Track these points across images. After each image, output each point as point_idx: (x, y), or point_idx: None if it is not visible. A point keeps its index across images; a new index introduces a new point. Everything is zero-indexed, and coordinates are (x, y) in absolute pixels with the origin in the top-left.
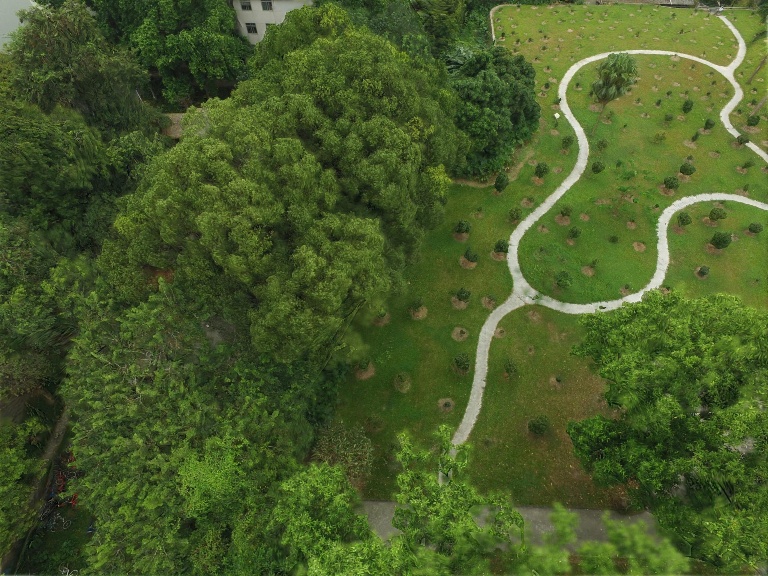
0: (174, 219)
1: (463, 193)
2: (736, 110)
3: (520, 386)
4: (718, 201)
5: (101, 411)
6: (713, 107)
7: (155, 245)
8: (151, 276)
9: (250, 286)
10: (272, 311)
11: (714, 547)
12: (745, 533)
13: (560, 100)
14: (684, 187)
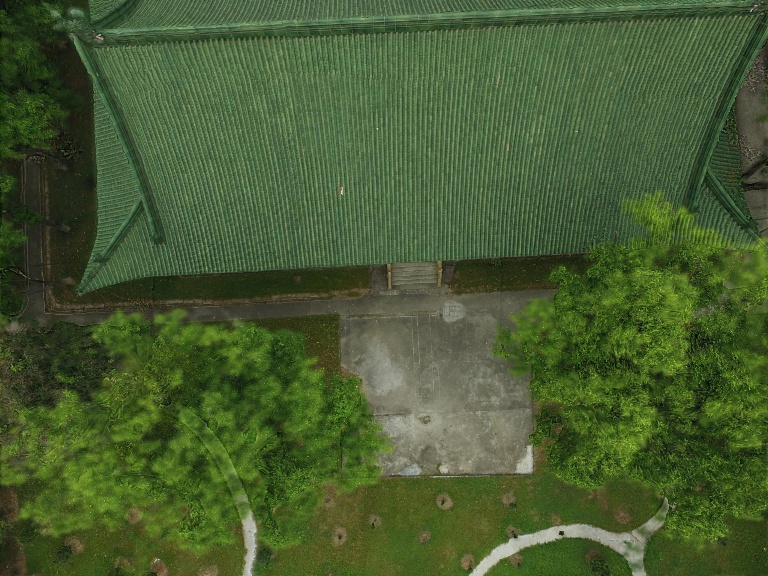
0: None
1: None
2: None
3: None
4: None
5: None
6: None
7: None
8: None
9: None
10: None
11: None
12: None
13: None
14: None
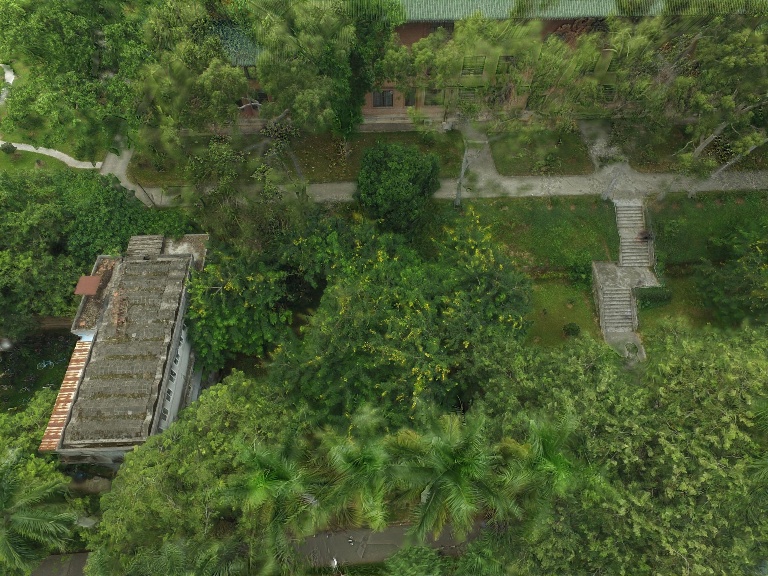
0: None
1: None
2: None
3: (43, 129)
4: None
5: None
6: None
7: None
8: None
9: None
10: None
11: None
12: None
13: None
14: None
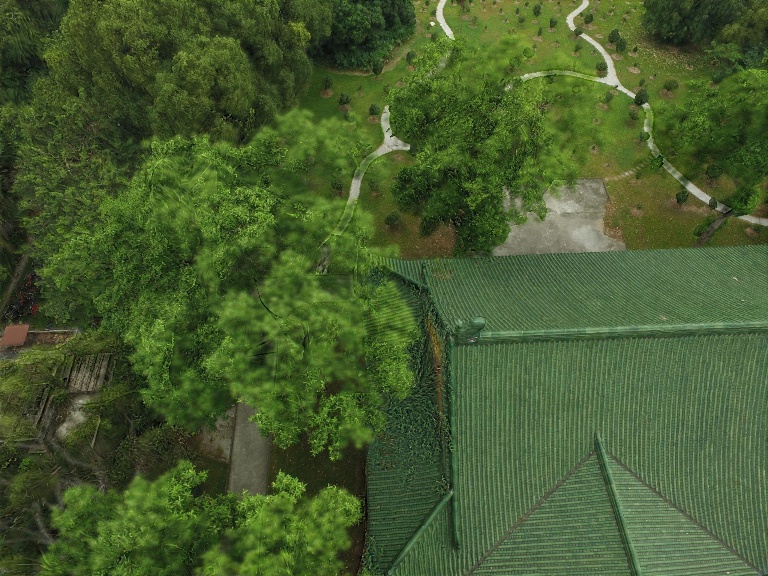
0: (84, 36)
1: (349, 80)
2: (580, 14)
3: (383, 201)
4: (553, 75)
5: (42, 186)
6: (562, 13)
7: (76, 71)
8: (75, 96)
9: (145, 85)
10: (160, 95)
11: (420, 166)
12: None
13: (435, 11)
14: (527, 67)
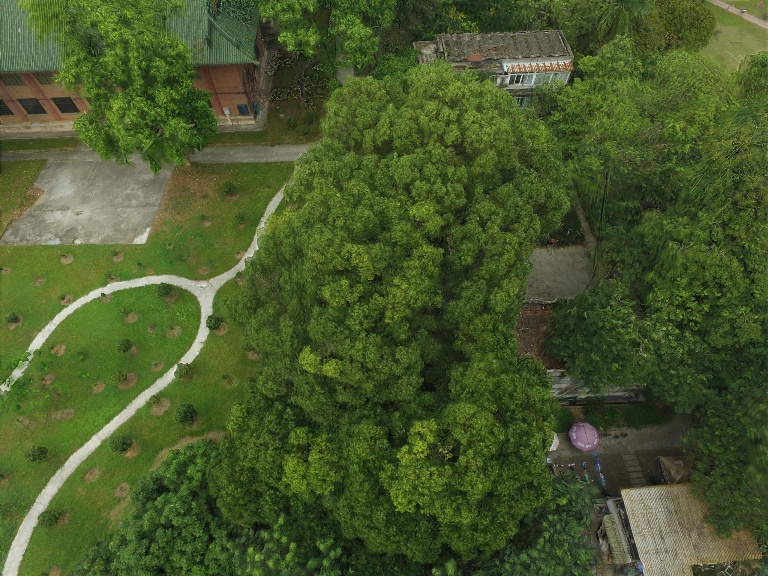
0: None
1: None
2: None
3: None
4: None
5: None
6: None
7: None
8: None
9: None
10: None
11: None
12: (167, 2)
13: None
14: None
